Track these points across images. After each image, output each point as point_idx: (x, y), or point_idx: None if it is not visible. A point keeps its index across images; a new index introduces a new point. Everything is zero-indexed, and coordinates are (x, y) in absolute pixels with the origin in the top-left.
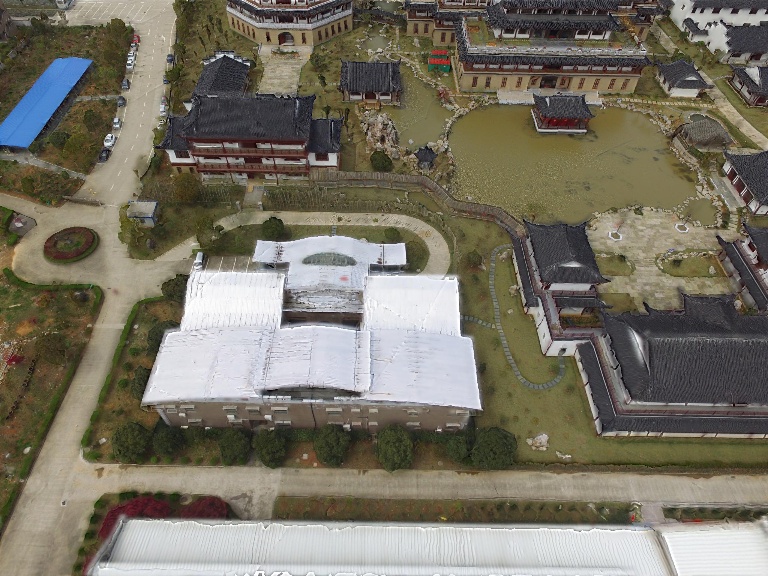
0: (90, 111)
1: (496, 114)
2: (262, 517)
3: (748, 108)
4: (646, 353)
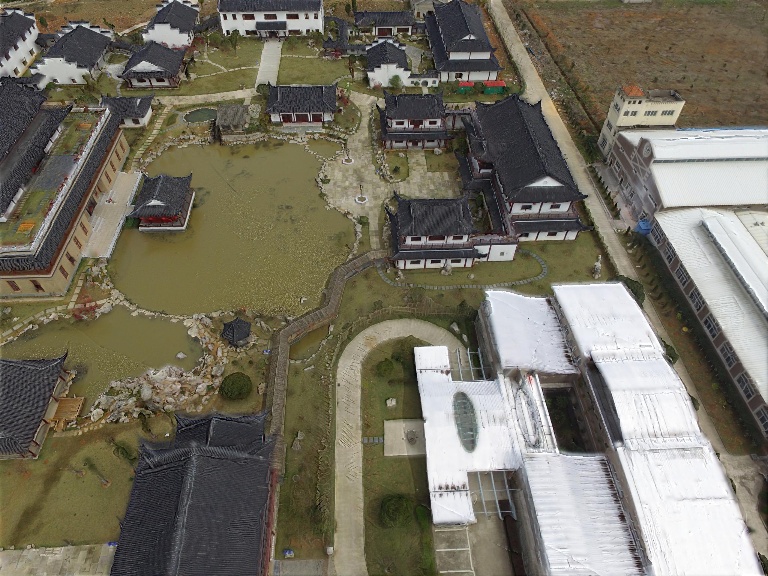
0: None
1: (130, 264)
2: (751, 463)
3: (179, 89)
4: (550, 182)
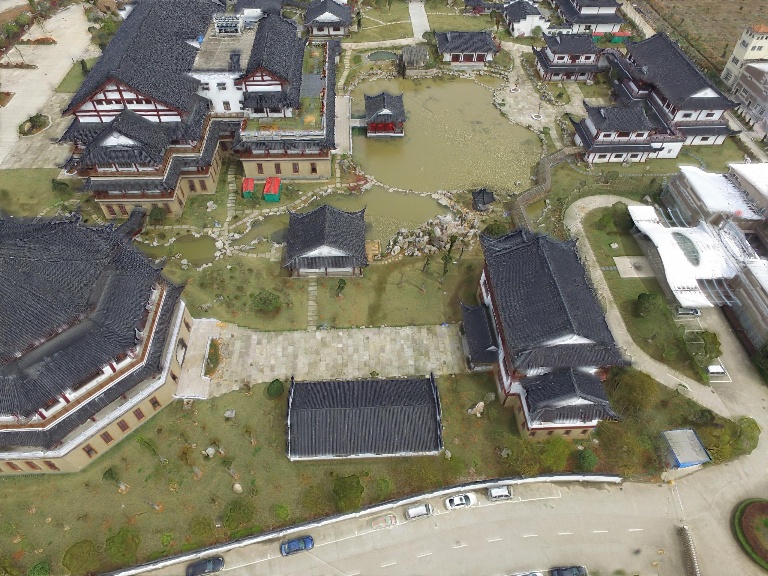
0: None
1: (369, 160)
2: None
3: (352, 38)
4: (710, 93)
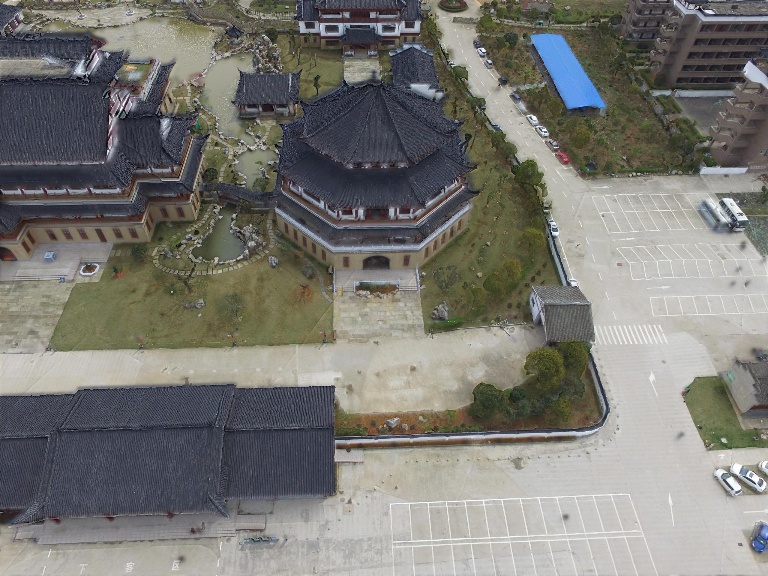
0: (499, 37)
1: None
2: None
3: None
4: None
